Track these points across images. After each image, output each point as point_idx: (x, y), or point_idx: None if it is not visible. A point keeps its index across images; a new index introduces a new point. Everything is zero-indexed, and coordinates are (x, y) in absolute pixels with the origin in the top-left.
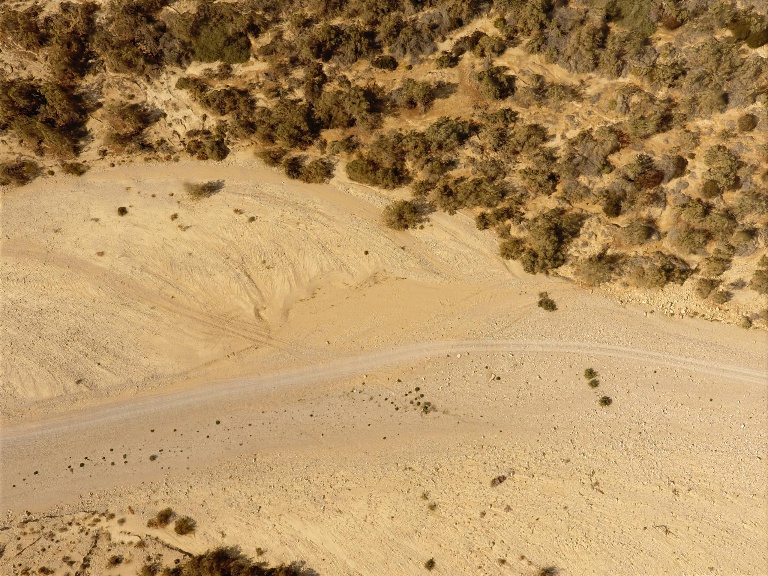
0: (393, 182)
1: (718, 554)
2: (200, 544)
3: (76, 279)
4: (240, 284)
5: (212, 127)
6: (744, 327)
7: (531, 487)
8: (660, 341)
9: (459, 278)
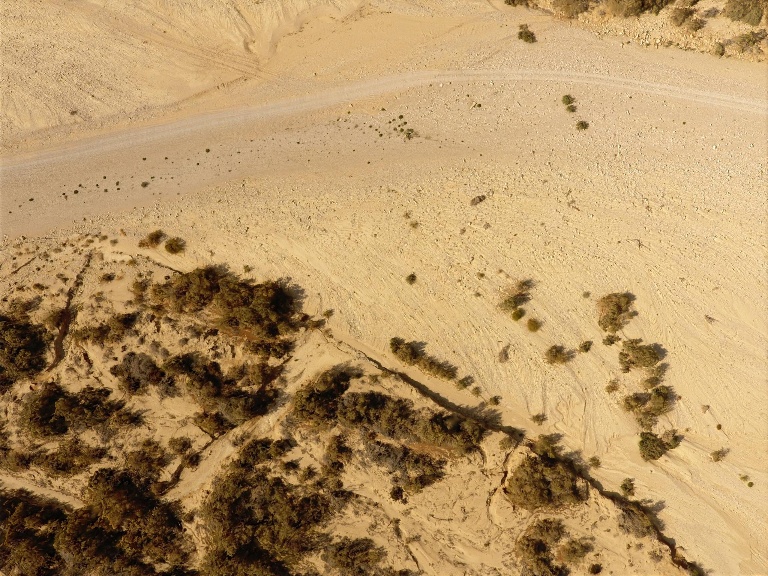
0: None
1: (689, 266)
2: (190, 263)
3: (71, 15)
4: (230, 18)
5: None
6: (717, 53)
7: (510, 206)
8: (636, 69)
9: (442, 12)
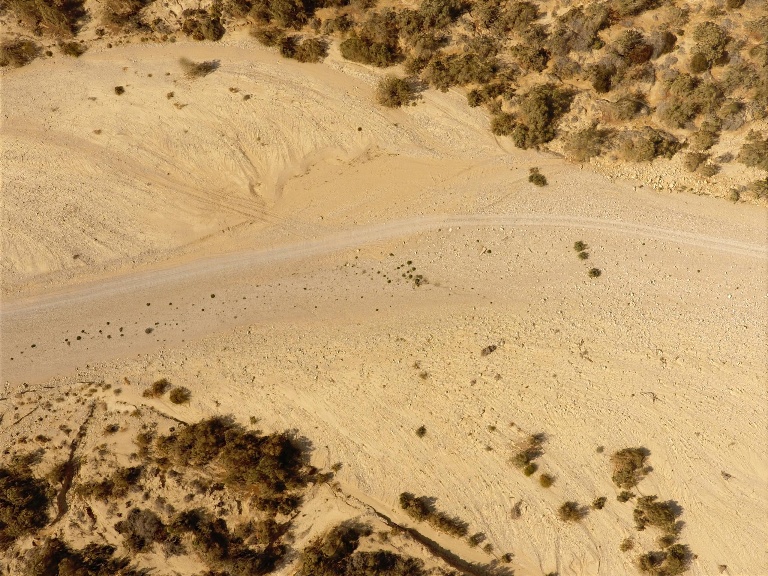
0: (386, 60)
1: (705, 420)
2: (195, 413)
3: (73, 157)
4: (235, 160)
5: (208, 6)
6: (731, 199)
7: (521, 356)
8: (649, 214)
9: (451, 154)
